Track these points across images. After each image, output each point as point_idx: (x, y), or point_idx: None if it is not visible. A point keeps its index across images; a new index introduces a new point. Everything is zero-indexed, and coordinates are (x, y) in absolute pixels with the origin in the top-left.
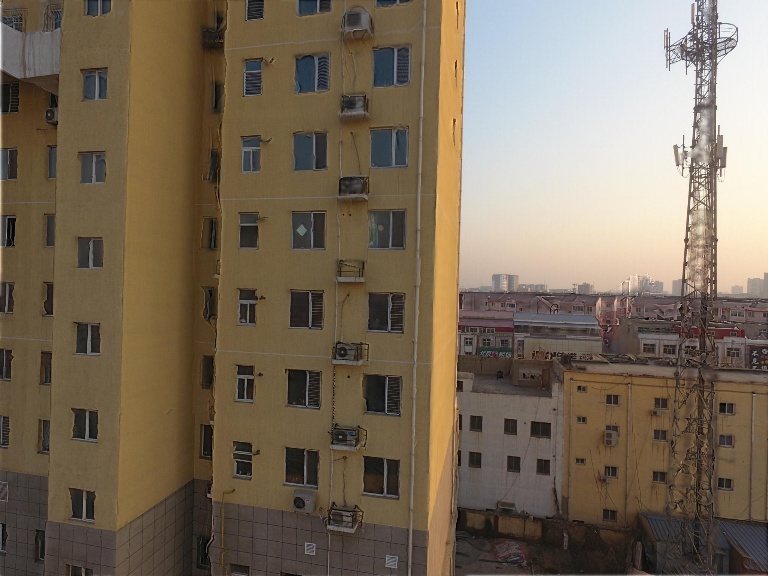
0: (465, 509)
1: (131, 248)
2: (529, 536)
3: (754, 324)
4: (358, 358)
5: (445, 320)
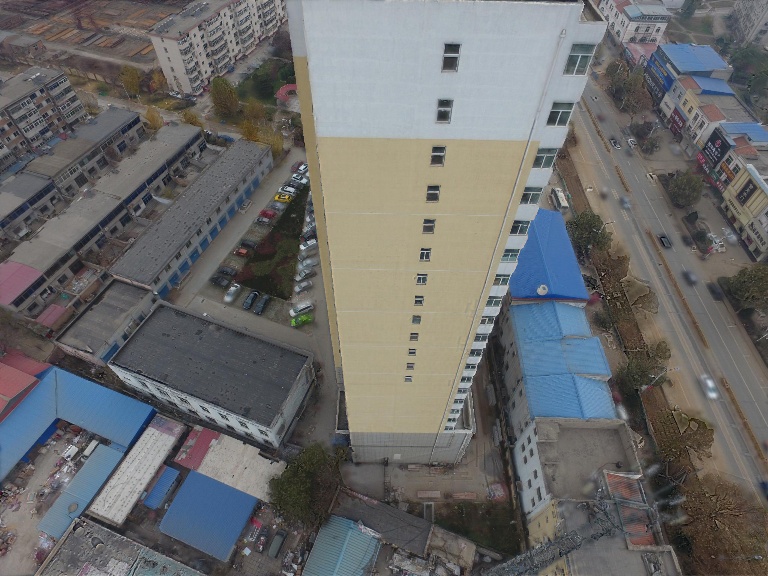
0: (510, 463)
1: (333, 333)
2: (513, 503)
3: None
4: None
5: (388, 412)
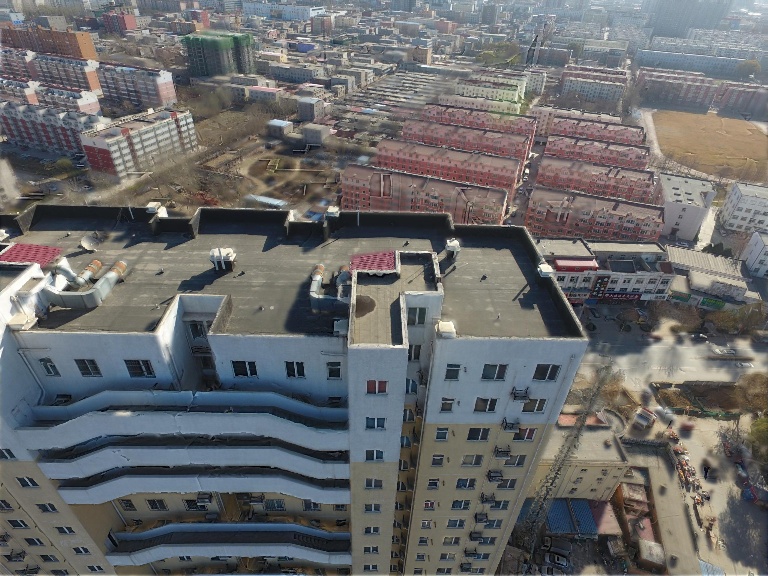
0: None
1: None
2: None
3: (607, 251)
4: None
5: None
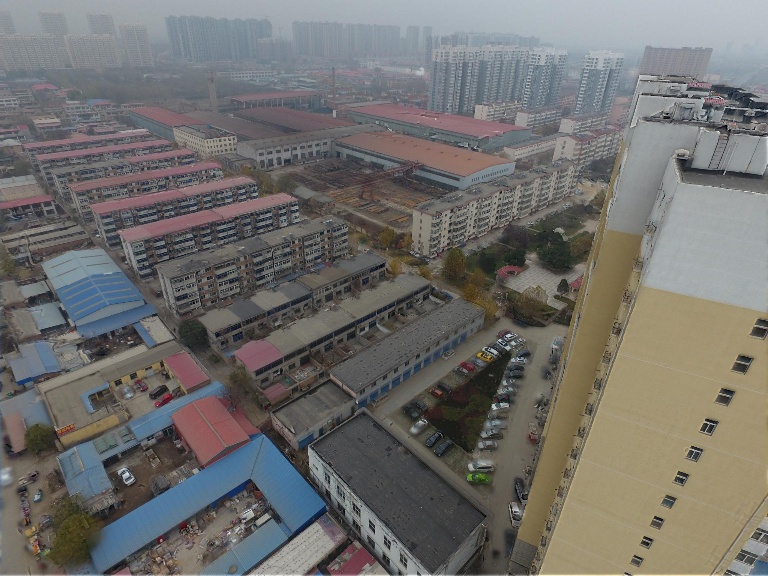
0: None
1: (532, 496)
2: None
3: None
4: (532, 574)
5: None
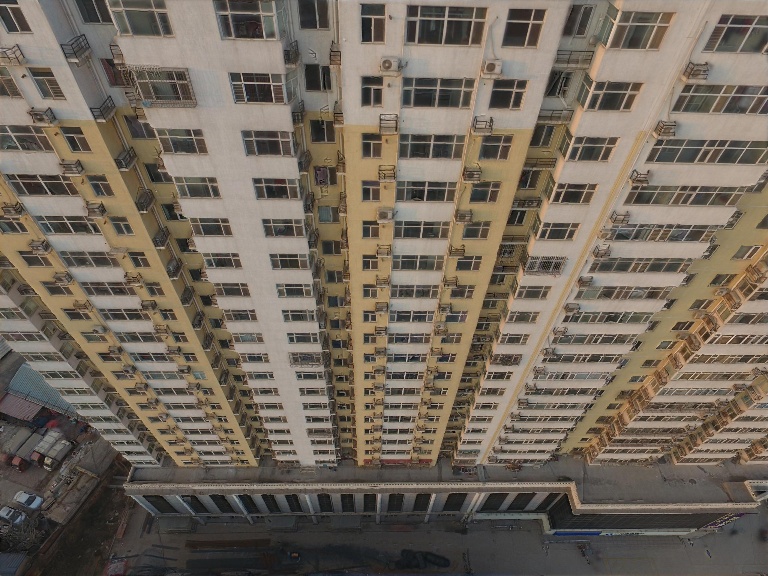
0: None
1: None
2: None
3: None
4: None
5: None
